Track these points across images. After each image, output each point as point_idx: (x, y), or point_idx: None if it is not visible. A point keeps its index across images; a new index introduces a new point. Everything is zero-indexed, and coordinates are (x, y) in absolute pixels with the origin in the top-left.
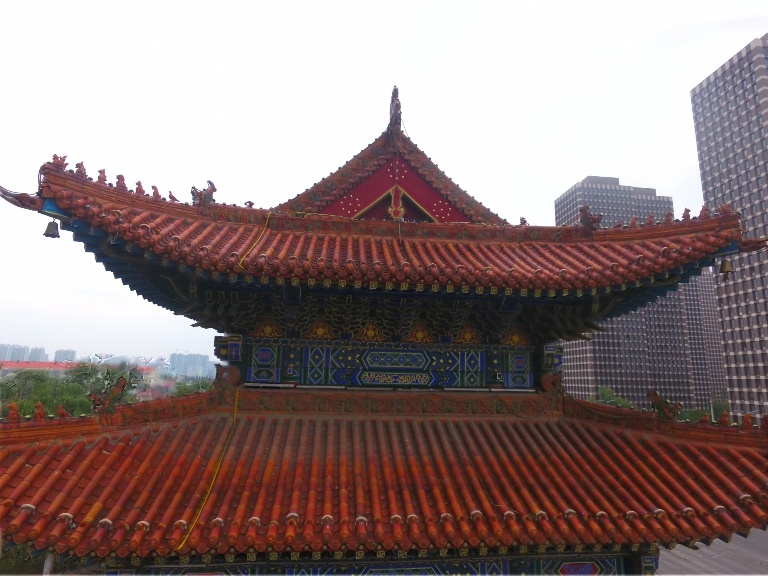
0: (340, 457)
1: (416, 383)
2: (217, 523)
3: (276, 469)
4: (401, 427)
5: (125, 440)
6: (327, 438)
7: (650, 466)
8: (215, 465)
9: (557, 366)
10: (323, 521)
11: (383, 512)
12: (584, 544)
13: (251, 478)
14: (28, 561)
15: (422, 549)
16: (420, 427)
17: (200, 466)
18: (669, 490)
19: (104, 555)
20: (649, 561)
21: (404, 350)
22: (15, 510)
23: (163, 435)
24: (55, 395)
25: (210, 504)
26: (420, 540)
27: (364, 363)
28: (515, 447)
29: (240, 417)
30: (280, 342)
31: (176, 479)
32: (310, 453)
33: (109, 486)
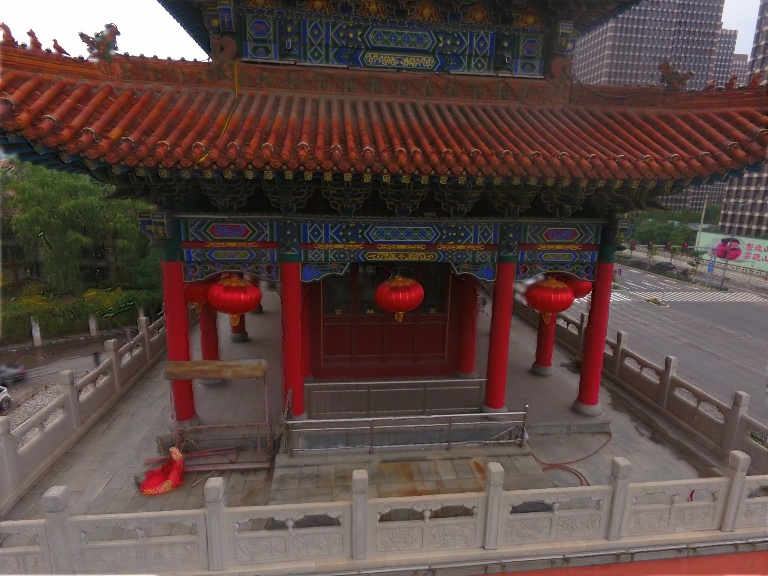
0: (345, 121)
1: (421, 67)
2: (233, 145)
3: (283, 127)
4: (405, 107)
5: (129, 91)
6: (331, 110)
7: (647, 134)
8: (223, 122)
9: (570, 53)
10: (332, 149)
11: (388, 152)
12: (573, 179)
13: (260, 127)
14: (74, 319)
15: (424, 175)
16: (424, 109)
17: (209, 122)
18: (661, 147)
19: (132, 164)
20: (625, 224)
21: (409, 29)
22: (37, 122)
23: (166, 95)
24: (54, 179)
25: (223, 138)
26: (423, 166)
27: (366, 42)
28: (517, 124)
29: (242, 93)
30: (275, 14)
31: (187, 126)
32: (315, 120)
33: (123, 119)
